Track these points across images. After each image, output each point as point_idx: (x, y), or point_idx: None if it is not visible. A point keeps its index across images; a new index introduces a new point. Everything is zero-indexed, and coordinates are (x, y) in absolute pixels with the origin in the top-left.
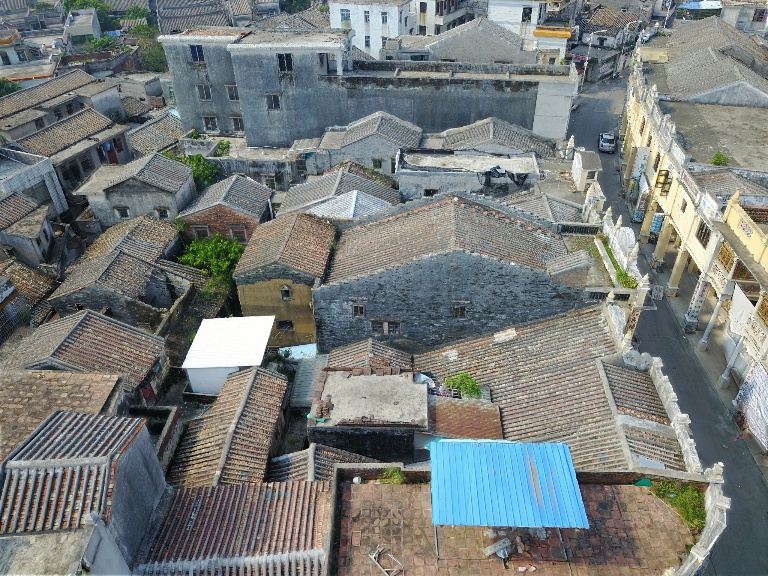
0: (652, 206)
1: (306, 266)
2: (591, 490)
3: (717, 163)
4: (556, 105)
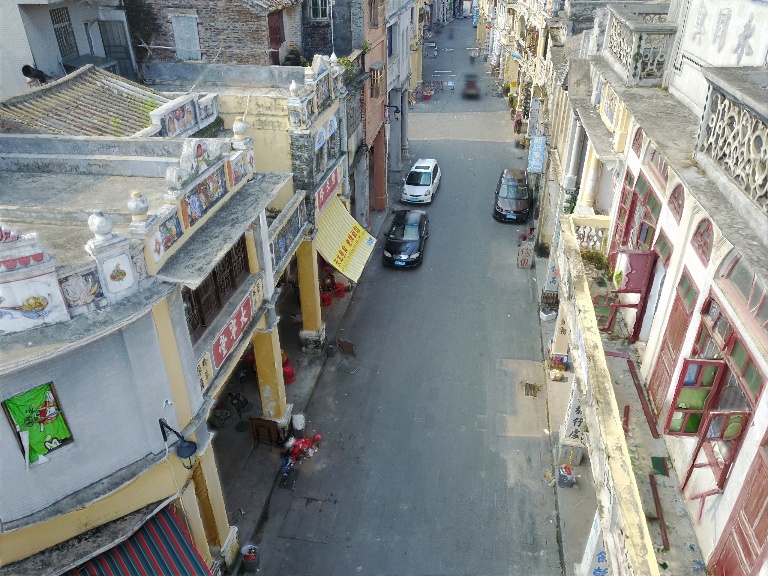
0: None
1: None
2: None
3: None
4: None
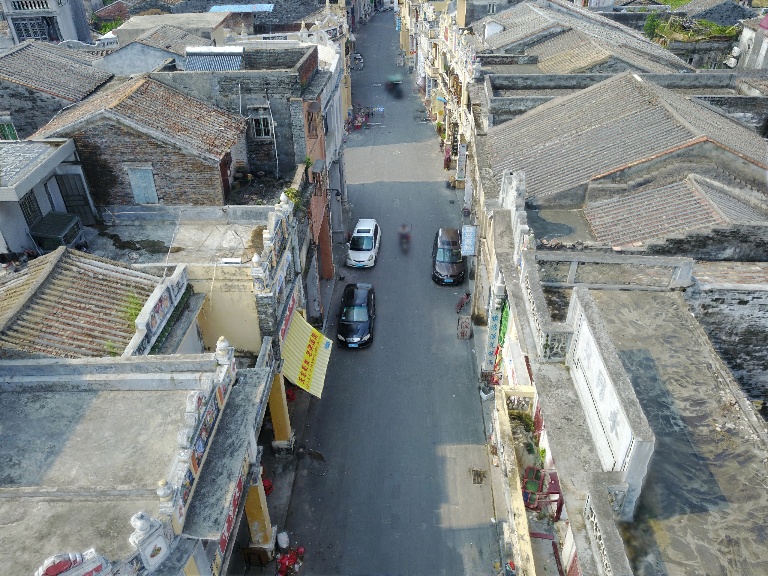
0: (402, 22)
1: (168, 1)
2: (289, 31)
3: None
4: None
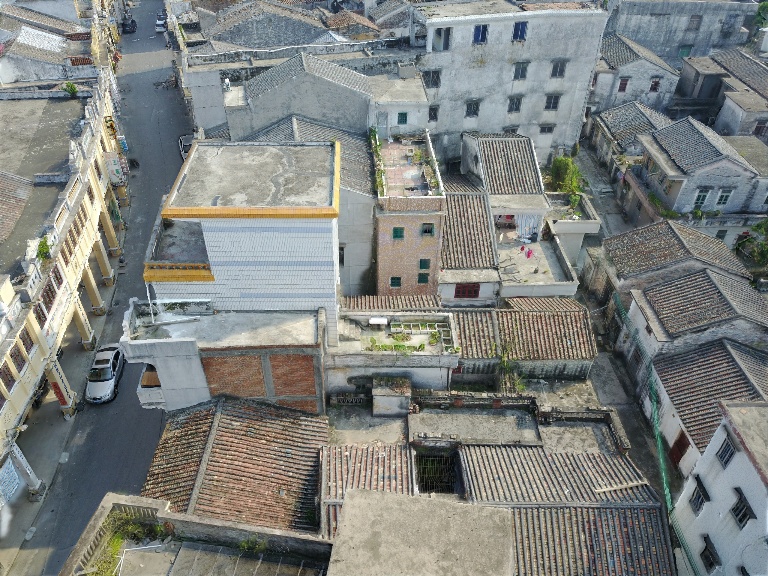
0: None
1: None
2: None
3: None
4: None
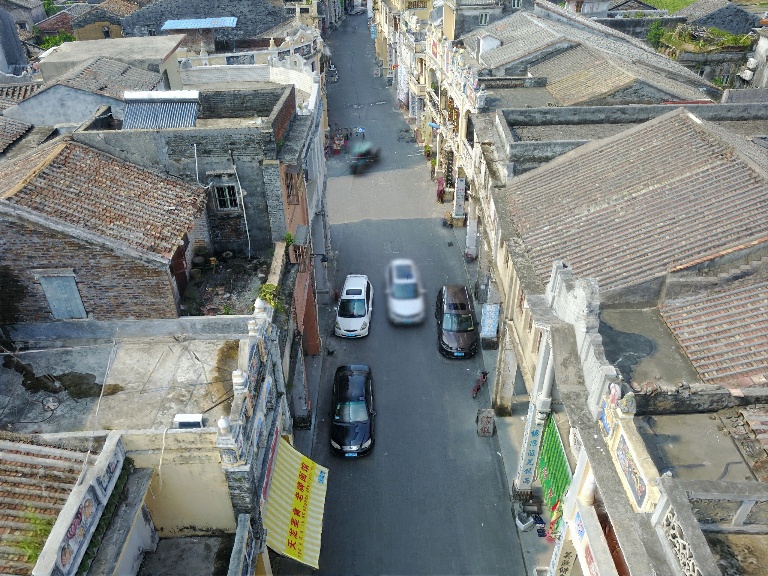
0: (377, 29)
1: (118, 13)
2: None
3: None
4: None
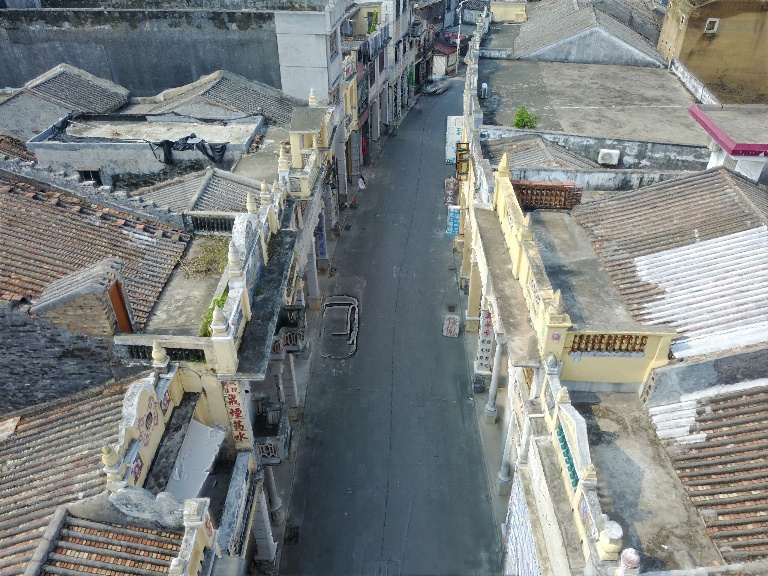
0: (462, 198)
1: None
2: None
3: (519, 124)
4: (306, 49)
